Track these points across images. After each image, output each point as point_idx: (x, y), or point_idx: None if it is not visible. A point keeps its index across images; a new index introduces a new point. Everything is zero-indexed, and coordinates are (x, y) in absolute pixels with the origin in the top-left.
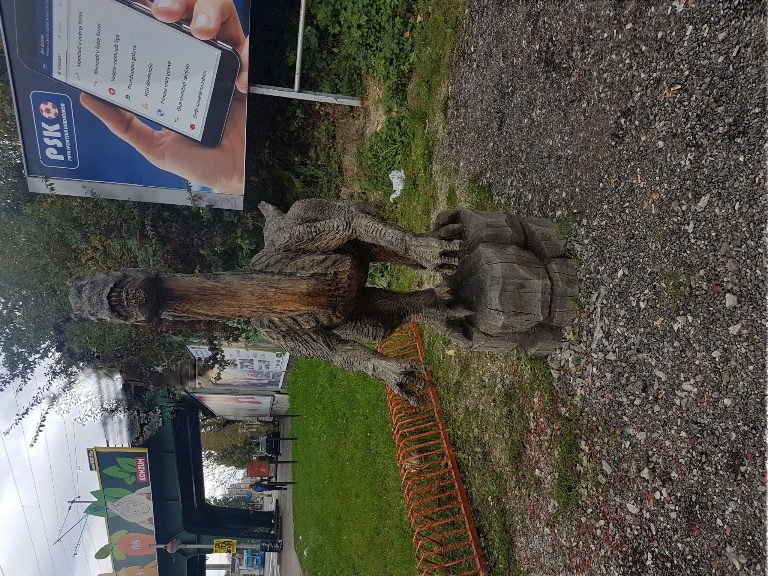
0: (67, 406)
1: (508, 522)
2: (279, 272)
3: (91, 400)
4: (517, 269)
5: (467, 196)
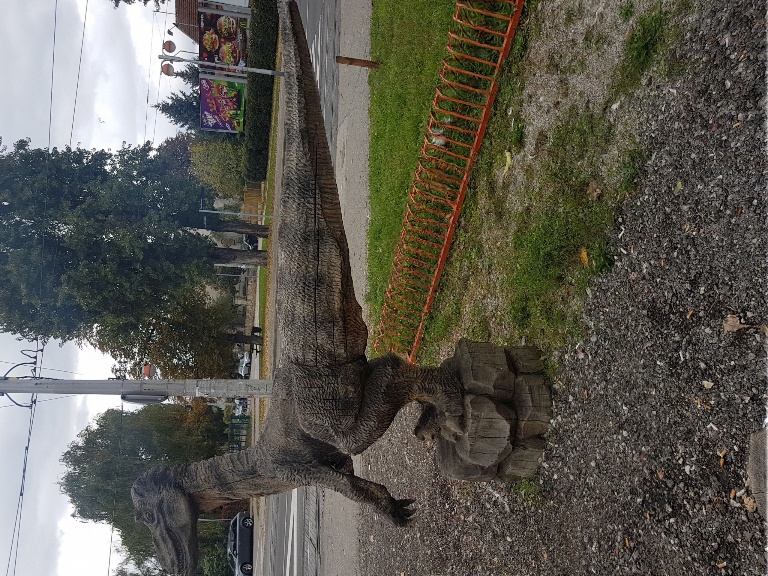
0: None
1: (449, 329)
2: None
3: None
4: None
5: (626, 145)
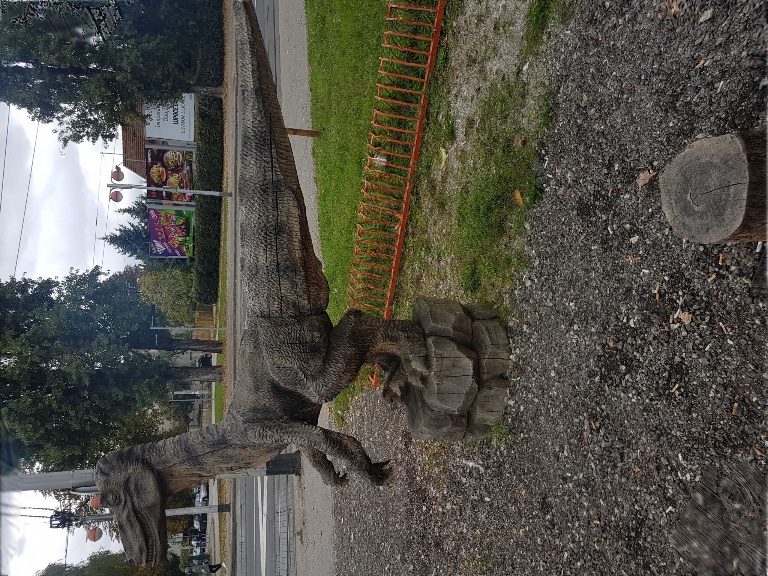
0: None
1: None
2: None
3: None
4: None
5: (539, 92)
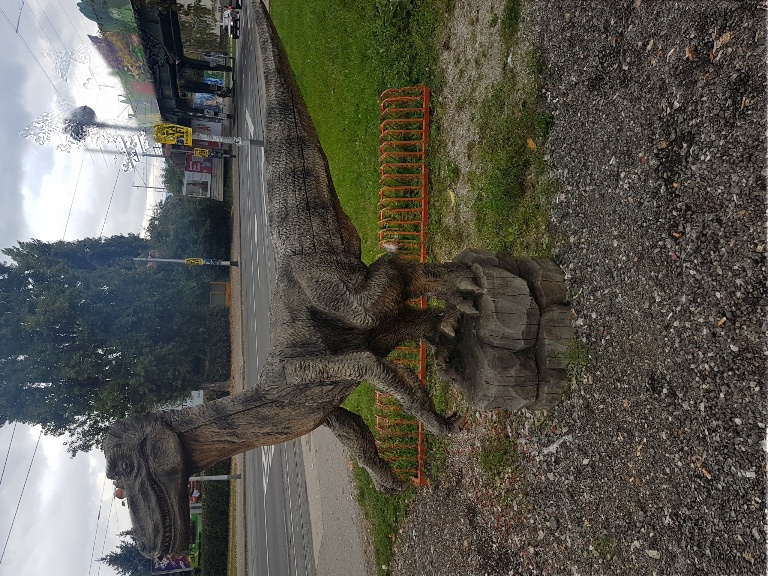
0: (46, 135)
1: (449, 395)
2: (289, 402)
3: (69, 125)
4: (511, 391)
5: (527, 60)
